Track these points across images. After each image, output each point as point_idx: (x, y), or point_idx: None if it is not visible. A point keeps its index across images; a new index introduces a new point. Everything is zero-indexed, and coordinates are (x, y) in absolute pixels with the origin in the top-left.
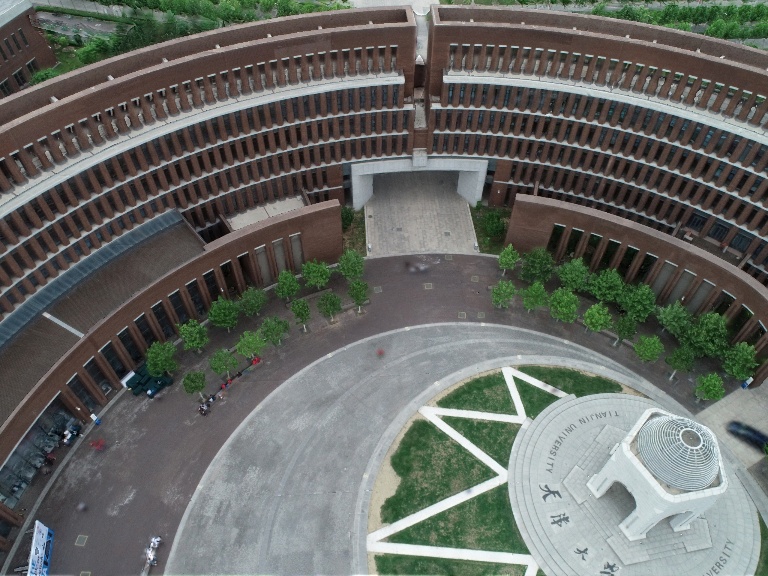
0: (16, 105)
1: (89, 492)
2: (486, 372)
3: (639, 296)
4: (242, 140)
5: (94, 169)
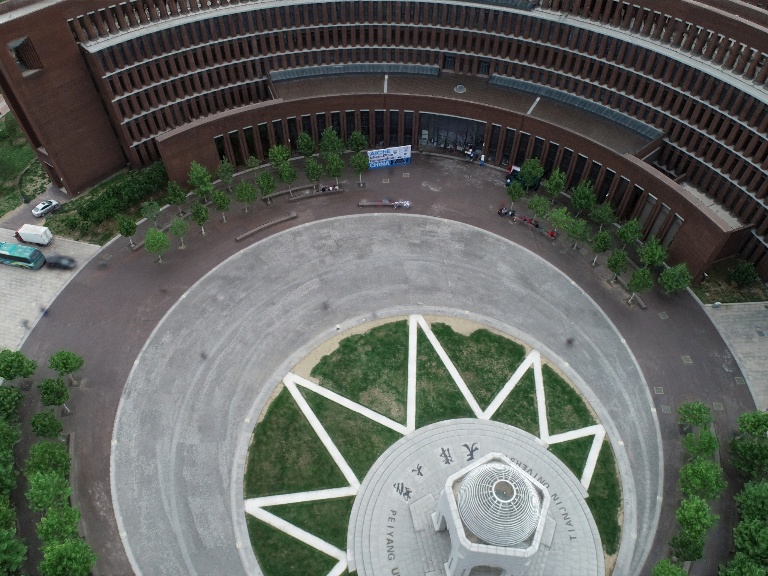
0: None
1: (435, 171)
2: (592, 409)
3: (748, 569)
4: (752, 134)
5: (648, 53)
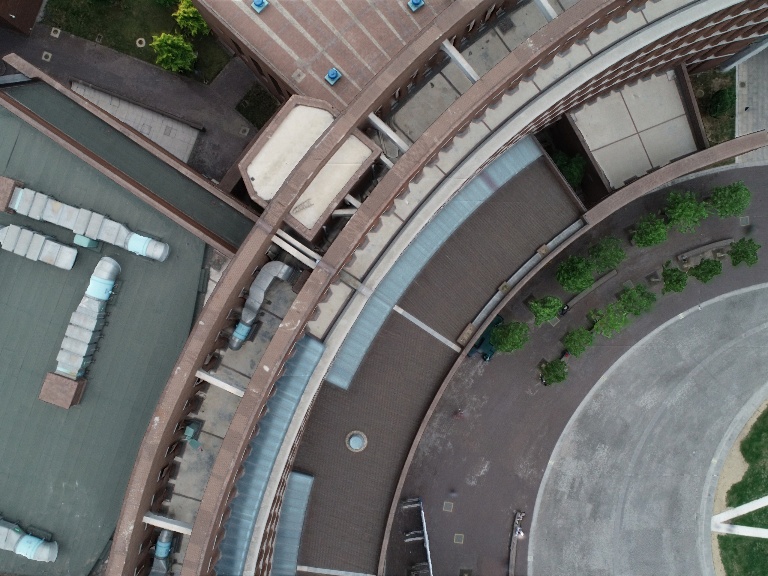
0: (401, 76)
1: (444, 461)
2: None
3: None
4: None
5: None
